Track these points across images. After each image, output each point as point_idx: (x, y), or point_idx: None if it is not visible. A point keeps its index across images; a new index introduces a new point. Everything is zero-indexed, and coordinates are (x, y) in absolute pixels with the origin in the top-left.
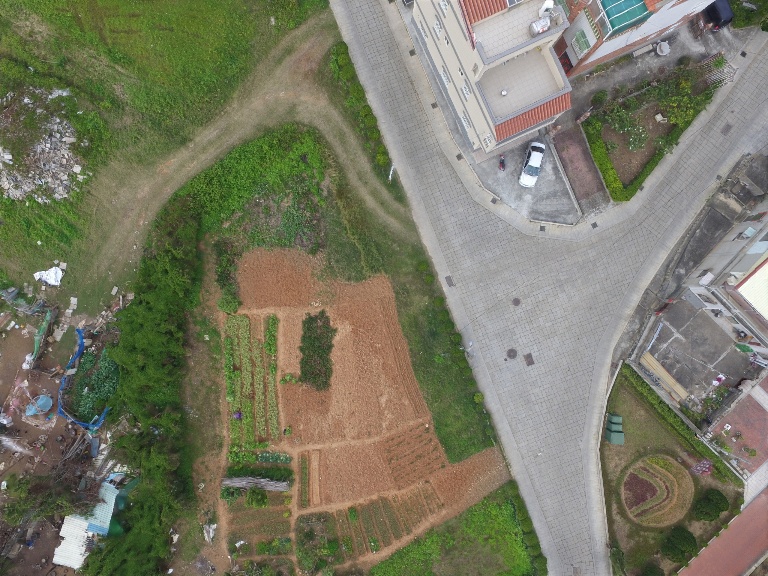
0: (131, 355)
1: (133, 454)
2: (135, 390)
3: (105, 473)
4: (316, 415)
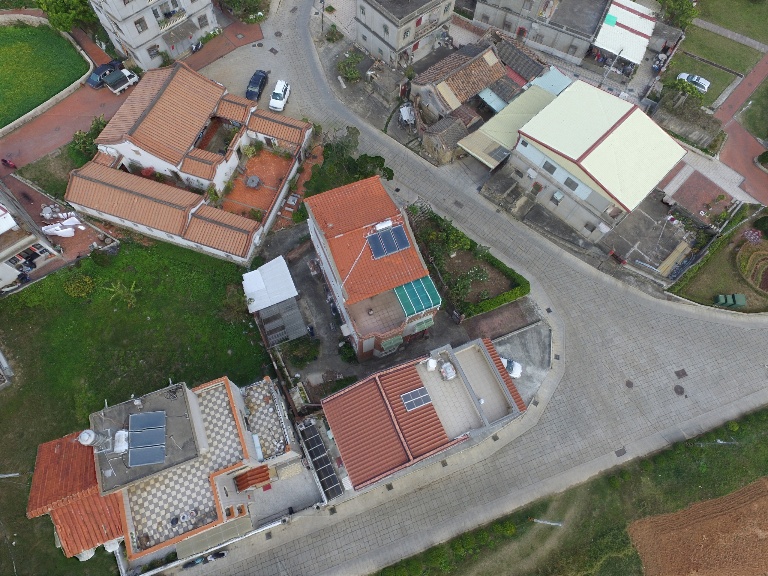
0: None
1: None
2: None
3: None
4: None
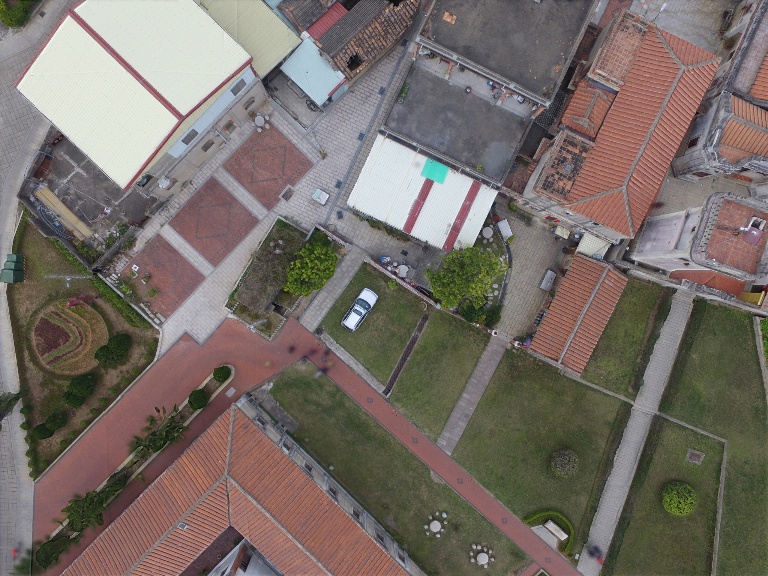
0: None
1: None
2: None
3: None
4: None
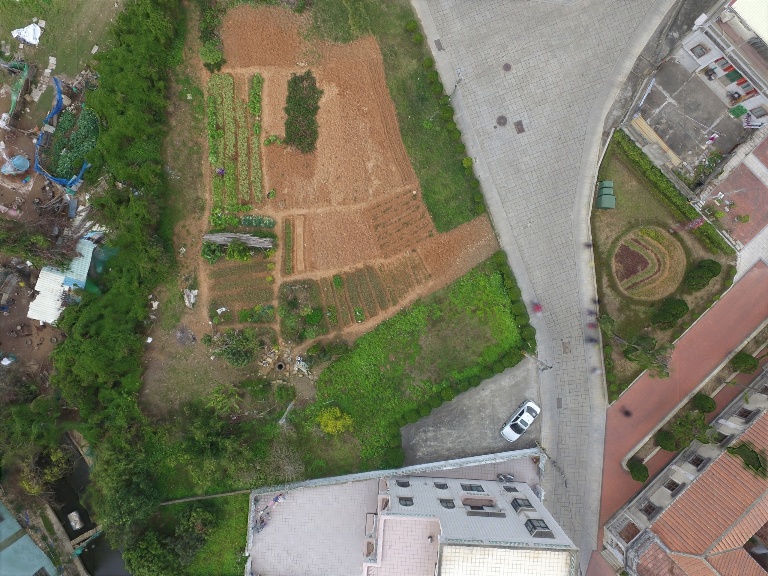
0: (110, 95)
1: (112, 213)
2: (114, 138)
3: (83, 231)
4: (301, 179)
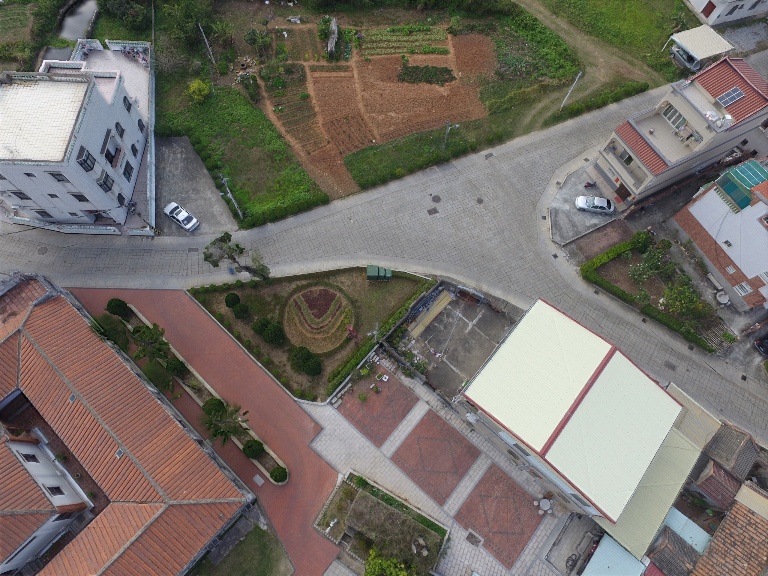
0: None
1: None
2: None
3: None
4: (379, 75)
